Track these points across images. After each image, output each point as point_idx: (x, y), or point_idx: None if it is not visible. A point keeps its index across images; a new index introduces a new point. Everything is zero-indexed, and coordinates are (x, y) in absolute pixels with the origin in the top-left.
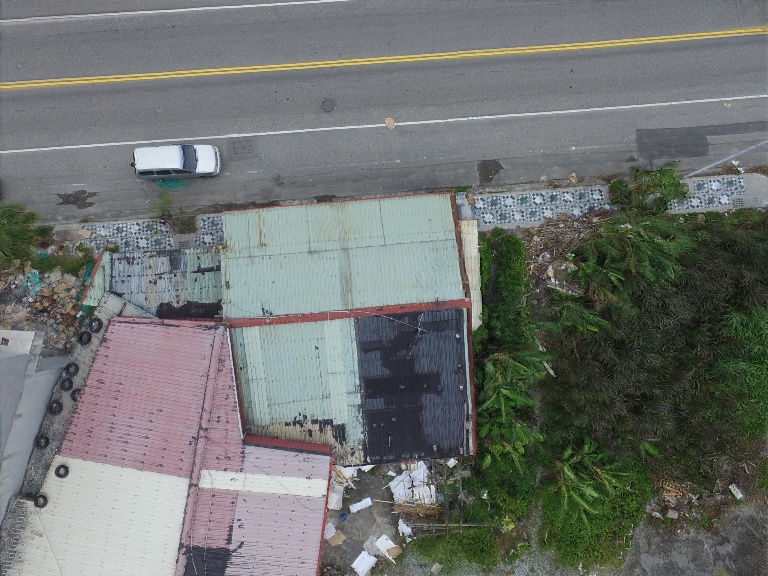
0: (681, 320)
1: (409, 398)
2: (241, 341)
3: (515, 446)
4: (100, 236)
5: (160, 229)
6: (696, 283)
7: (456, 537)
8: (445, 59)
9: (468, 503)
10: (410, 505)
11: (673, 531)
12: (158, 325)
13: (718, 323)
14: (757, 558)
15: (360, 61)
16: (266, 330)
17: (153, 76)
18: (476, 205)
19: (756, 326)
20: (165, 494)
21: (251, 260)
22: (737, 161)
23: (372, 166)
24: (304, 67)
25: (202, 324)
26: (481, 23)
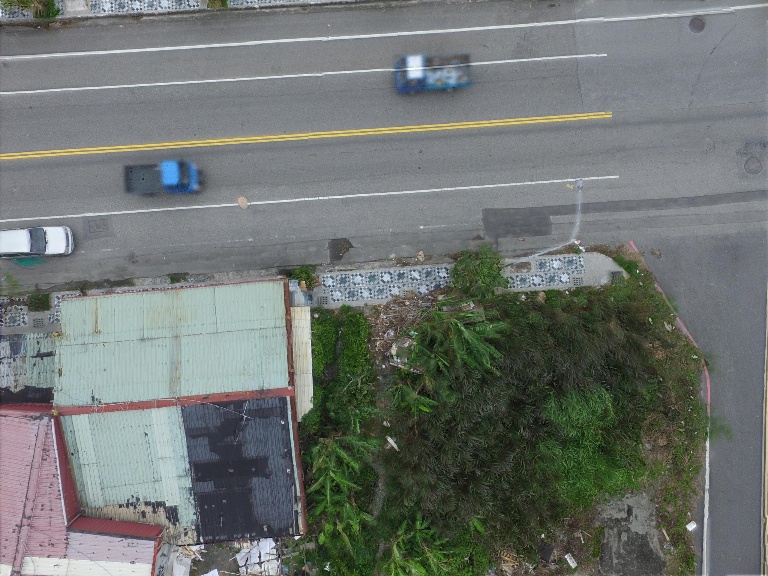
0: (513, 399)
1: (238, 481)
2: (71, 428)
3: (350, 522)
4: None
5: (15, 307)
6: (519, 368)
7: None
8: (297, 140)
9: (311, 574)
10: None
11: None
12: None
13: (541, 406)
14: None
15: (214, 142)
16: (95, 418)
17: (9, 156)
18: (325, 283)
19: (573, 411)
20: None
21: (85, 347)
22: (579, 240)
23: (225, 244)
24: (159, 148)
25: (27, 415)
26: (333, 105)
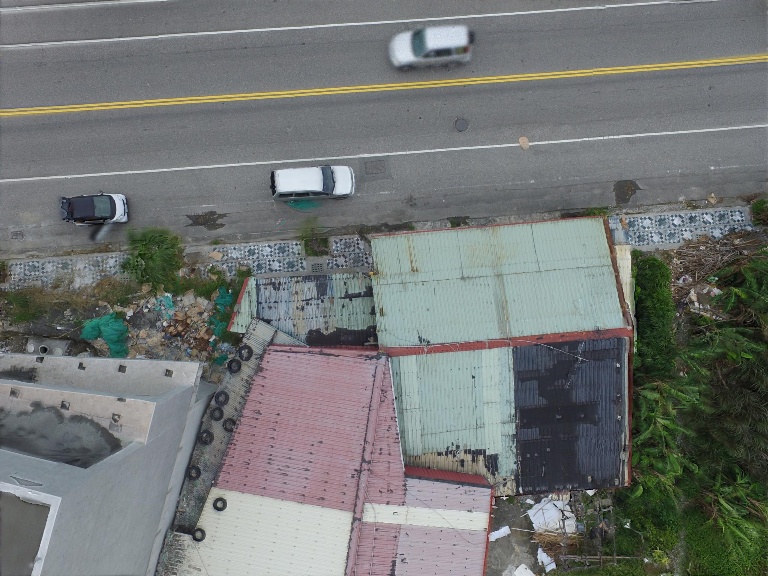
0: None
1: (565, 428)
2: (397, 370)
3: None
4: (231, 258)
5: (292, 251)
6: None
7: (607, 569)
8: (581, 77)
9: (610, 532)
10: (551, 534)
11: None
12: (316, 354)
13: None
14: None
15: (494, 79)
16: (423, 359)
17: (283, 95)
18: None
19: None
20: (328, 528)
21: (403, 286)
22: None
23: (506, 186)
24: (436, 85)
25: (363, 354)
26: (616, 40)
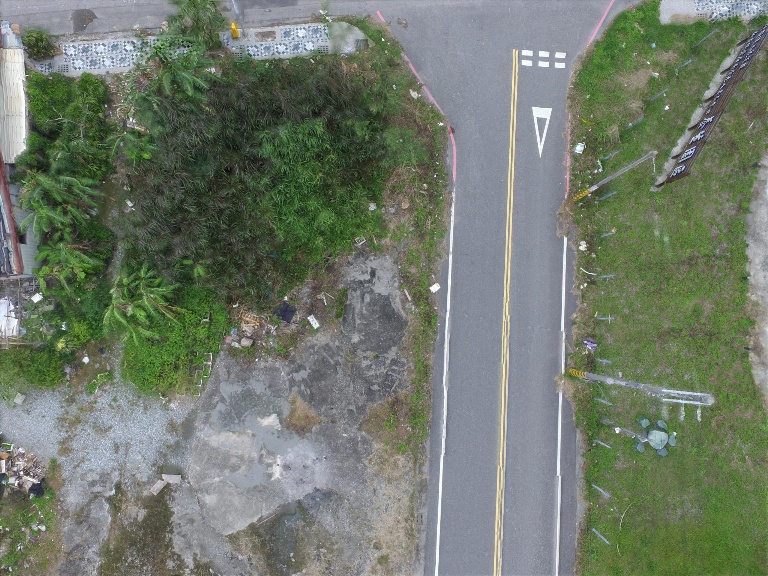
0: (242, 152)
1: None
2: None
3: (74, 271)
4: None
5: None
6: (234, 108)
7: (10, 357)
8: None
9: (48, 334)
10: None
11: (251, 360)
12: None
13: None
14: (331, 384)
15: None
16: None
17: None
18: (67, 52)
19: (283, 145)
20: None
21: None
22: (325, 10)
23: None
24: None
25: None
26: None
